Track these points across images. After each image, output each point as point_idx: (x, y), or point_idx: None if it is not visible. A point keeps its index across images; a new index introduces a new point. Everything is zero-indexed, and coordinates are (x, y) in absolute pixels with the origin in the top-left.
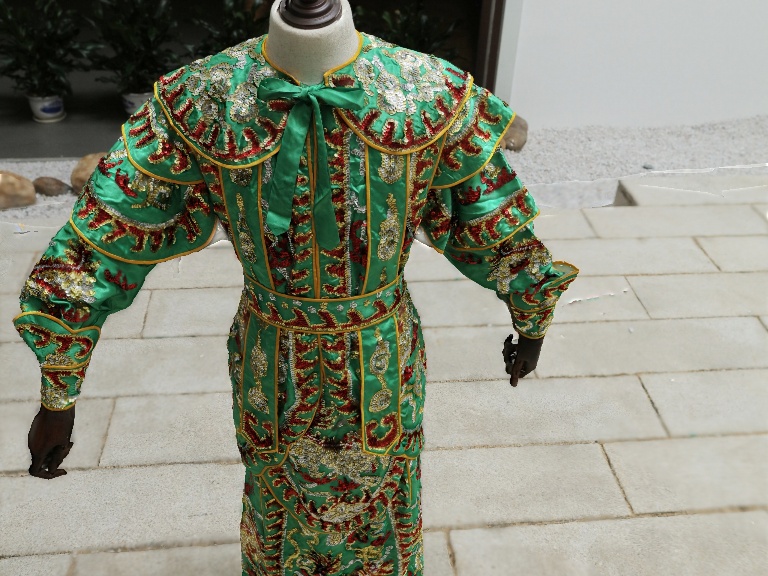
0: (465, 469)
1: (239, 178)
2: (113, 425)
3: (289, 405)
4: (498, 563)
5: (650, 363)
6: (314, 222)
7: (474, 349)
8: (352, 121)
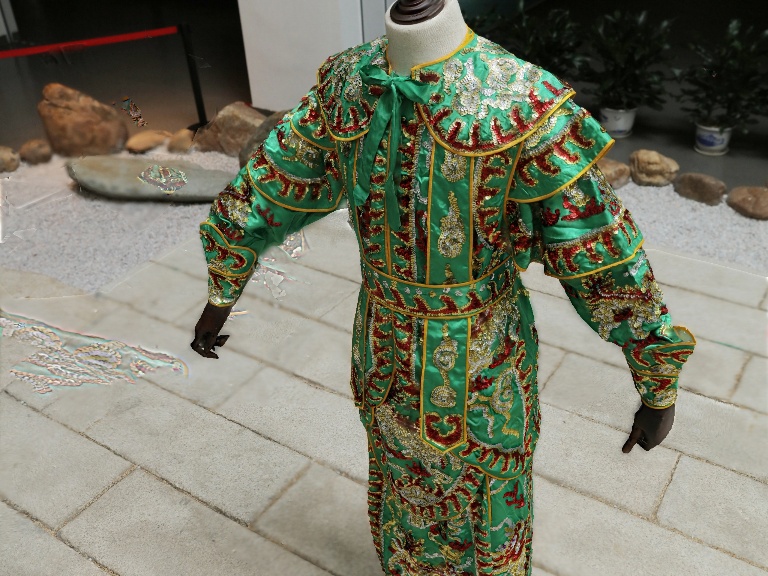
0: (689, 563)
1: (345, 150)
2: None
3: (367, 368)
4: None
5: None
6: (386, 202)
7: None
8: (427, 115)
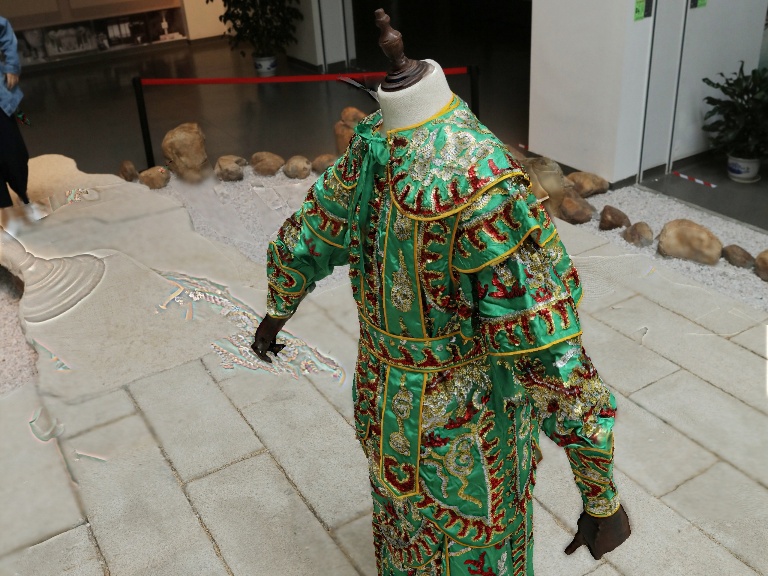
0: None
1: None
2: None
3: None
4: None
5: None
6: None
7: None
8: None
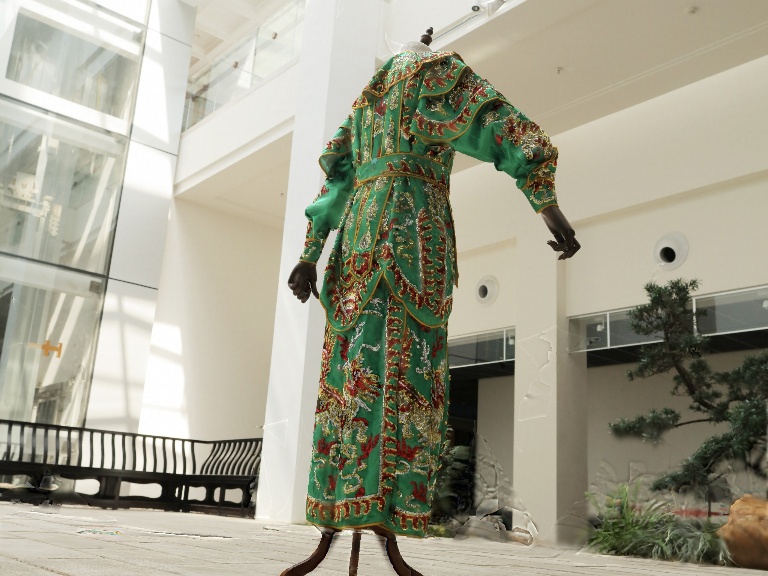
0: (101, 573)
1: None
2: None
3: None
4: None
5: None
6: None
7: None
8: None
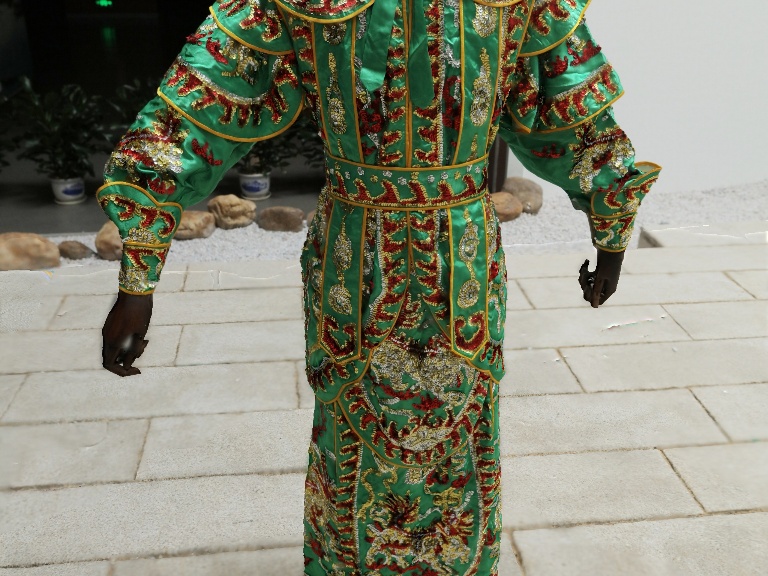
0: (522, 474)
1: (332, 36)
2: (149, 442)
3: (375, 295)
4: (568, 560)
5: (699, 377)
6: (408, 77)
7: (517, 369)
8: None
